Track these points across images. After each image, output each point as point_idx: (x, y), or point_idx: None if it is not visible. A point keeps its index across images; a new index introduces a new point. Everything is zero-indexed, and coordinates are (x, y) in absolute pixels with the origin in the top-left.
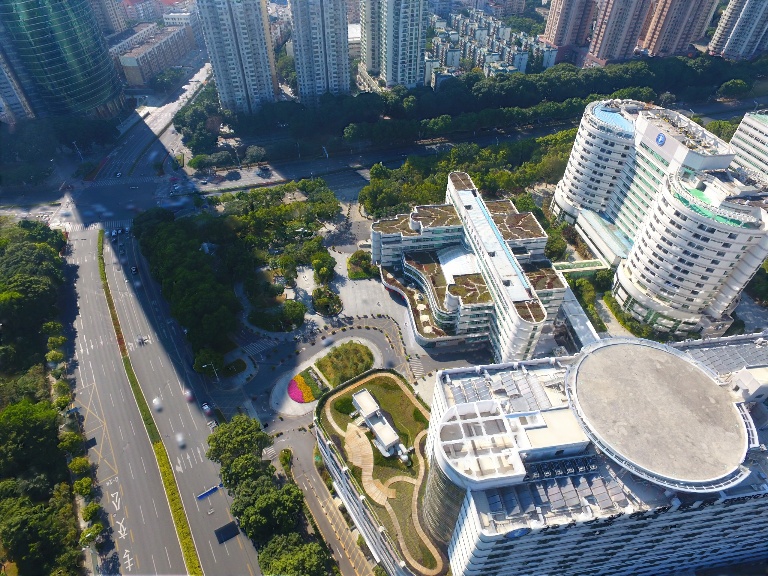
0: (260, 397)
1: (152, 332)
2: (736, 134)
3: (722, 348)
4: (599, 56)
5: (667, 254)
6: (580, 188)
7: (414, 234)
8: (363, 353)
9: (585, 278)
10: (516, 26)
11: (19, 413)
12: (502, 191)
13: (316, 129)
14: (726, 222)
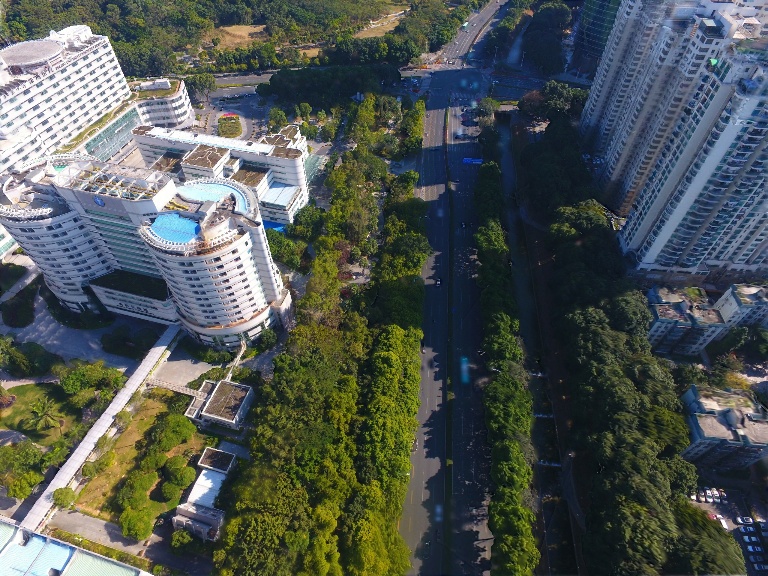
0: (238, 107)
1: None
2: None
3: None
4: None
5: None
6: None
7: None
8: None
9: None
10: None
11: None
12: None
13: None
14: None
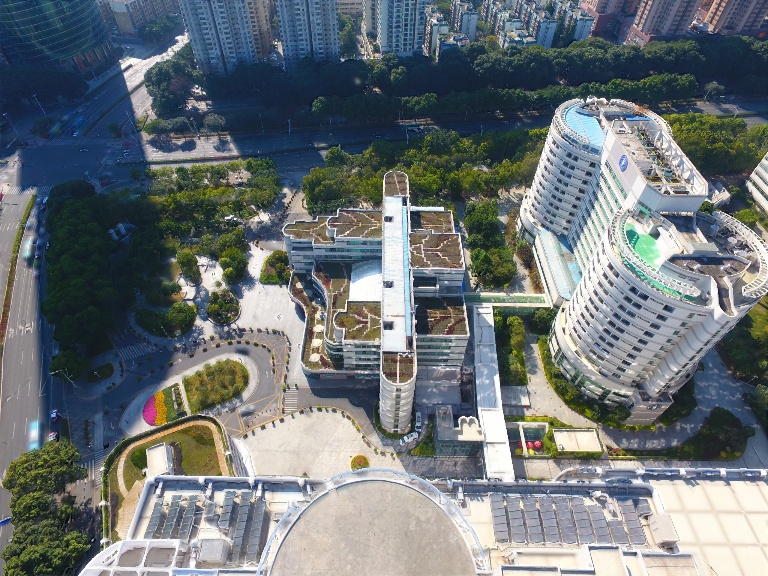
0: (113, 411)
1: (38, 319)
2: None
3: (539, 497)
4: (644, 30)
5: (597, 312)
6: (541, 204)
7: (327, 242)
8: (238, 375)
9: (523, 315)
10: None
11: None
12: (471, 191)
13: (290, 98)
14: (663, 289)
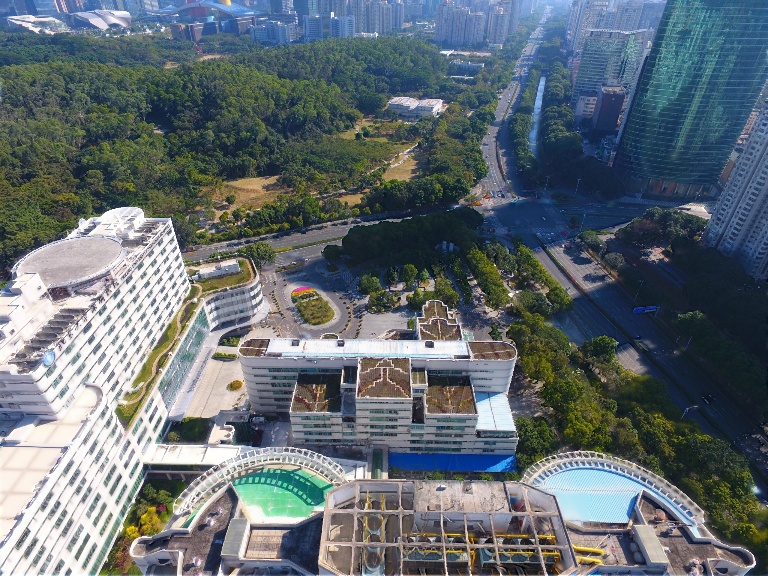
0: (306, 278)
1: None
2: None
3: (71, 325)
4: None
5: None
6: None
7: None
8: None
9: None
10: None
11: (309, 200)
12: None
13: None
14: None
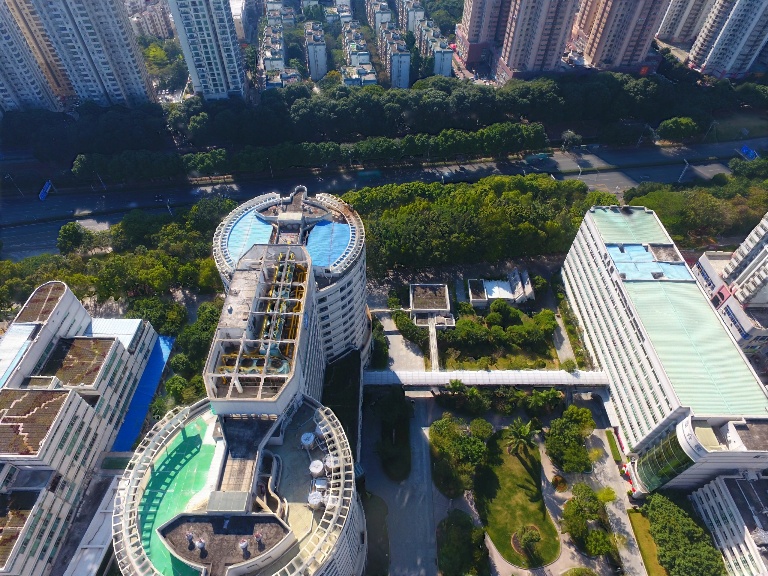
0: None
1: None
2: (577, 235)
3: None
4: (509, 64)
5: None
6: None
7: None
8: None
9: None
10: (448, 7)
11: None
12: None
13: (68, 151)
14: None
